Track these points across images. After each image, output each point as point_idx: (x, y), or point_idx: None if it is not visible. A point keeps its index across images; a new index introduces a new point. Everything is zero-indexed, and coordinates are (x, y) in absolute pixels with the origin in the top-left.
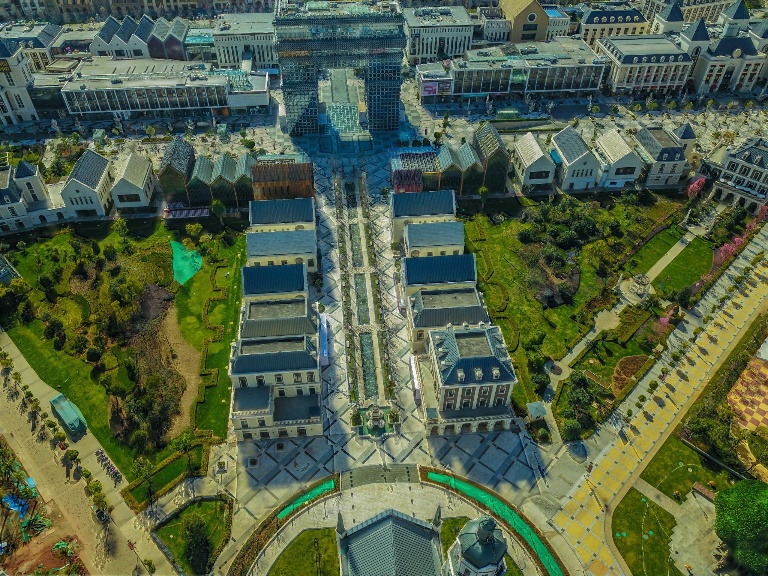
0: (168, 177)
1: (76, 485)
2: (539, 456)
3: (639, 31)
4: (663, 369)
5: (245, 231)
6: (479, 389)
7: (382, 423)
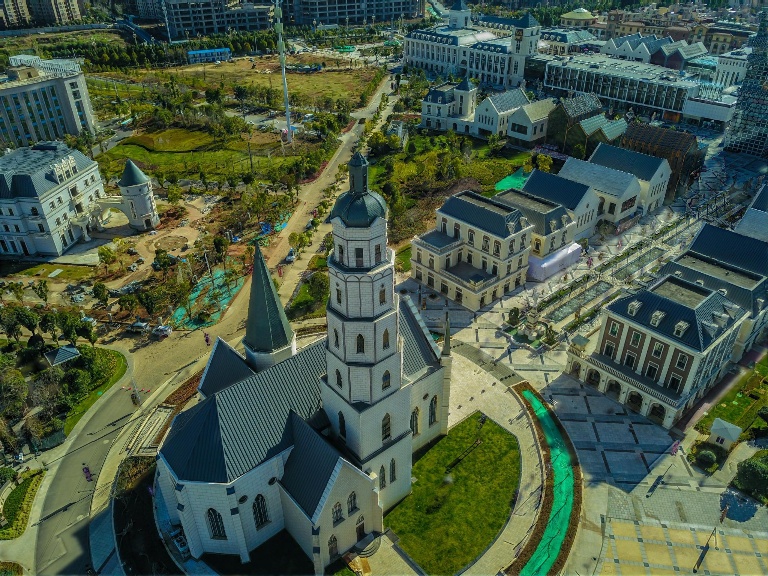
0: (557, 117)
1: None
2: (675, 470)
3: None
4: None
5: None
6: (650, 341)
7: (532, 334)
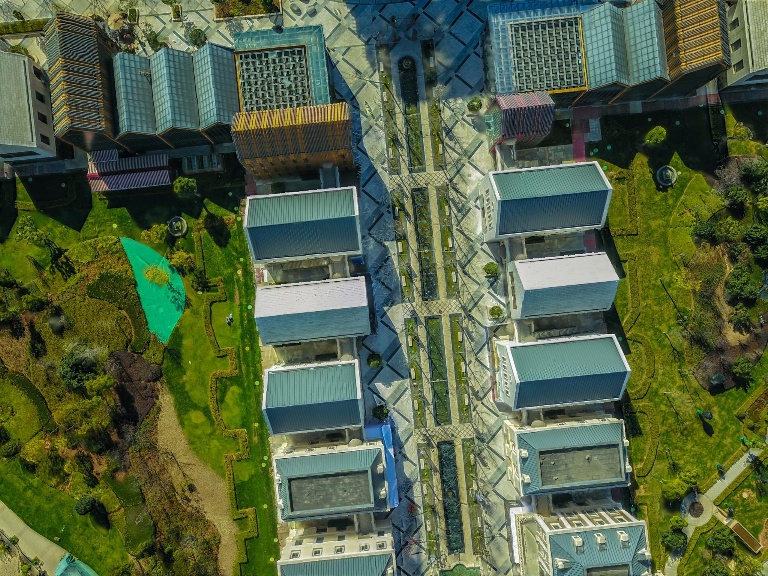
0: (75, 134)
1: None
2: None
3: None
4: None
5: (238, 210)
6: None
7: None
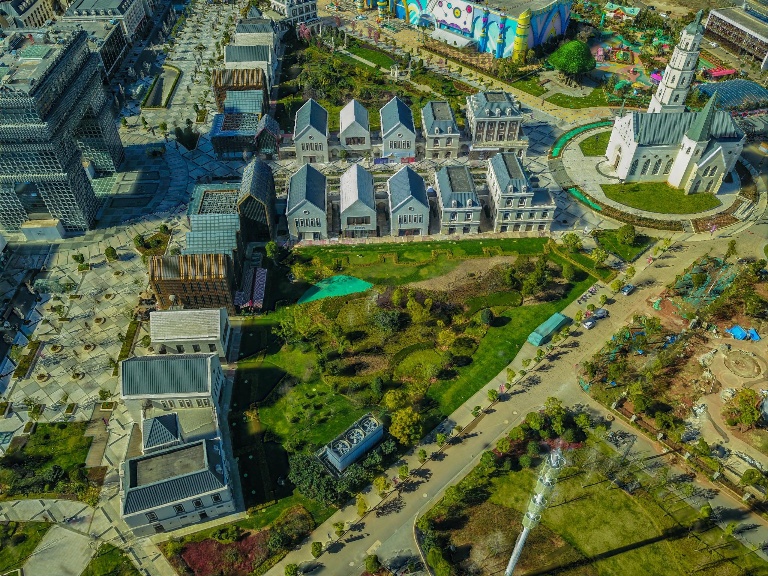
0: None
1: (609, 310)
2: (532, 122)
3: (46, 4)
4: (470, 74)
5: (290, 250)
6: None
7: None
